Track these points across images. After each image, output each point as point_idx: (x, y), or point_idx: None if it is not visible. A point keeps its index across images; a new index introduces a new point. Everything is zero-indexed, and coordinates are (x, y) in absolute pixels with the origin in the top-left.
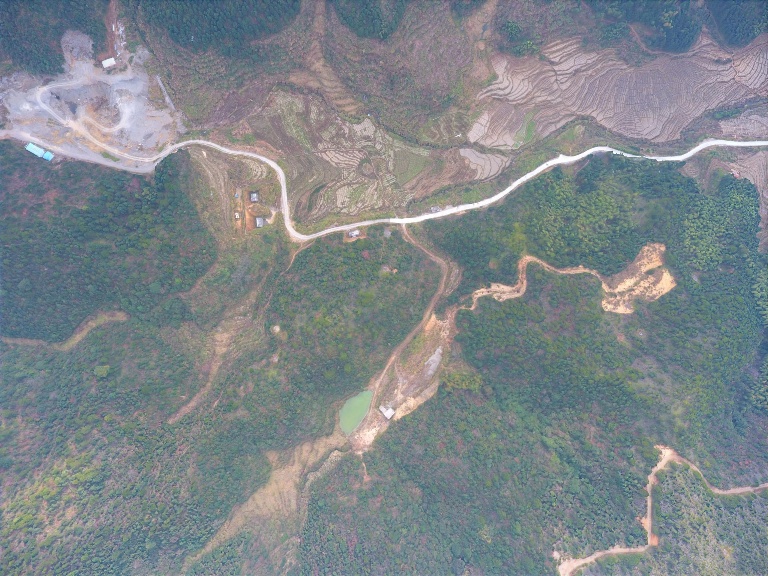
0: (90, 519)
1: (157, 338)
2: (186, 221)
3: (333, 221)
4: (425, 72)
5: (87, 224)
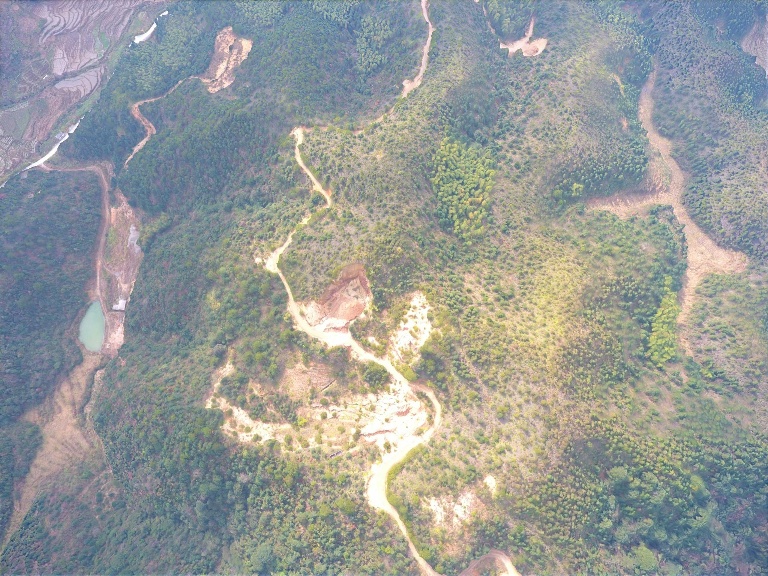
0: None
1: None
2: None
3: None
4: None
5: None
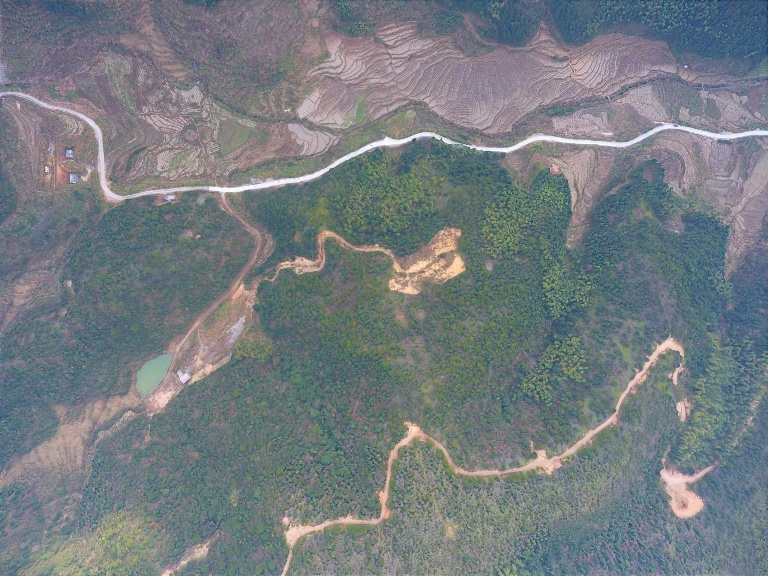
0: None
1: None
2: None
3: (151, 184)
4: (252, 43)
5: None
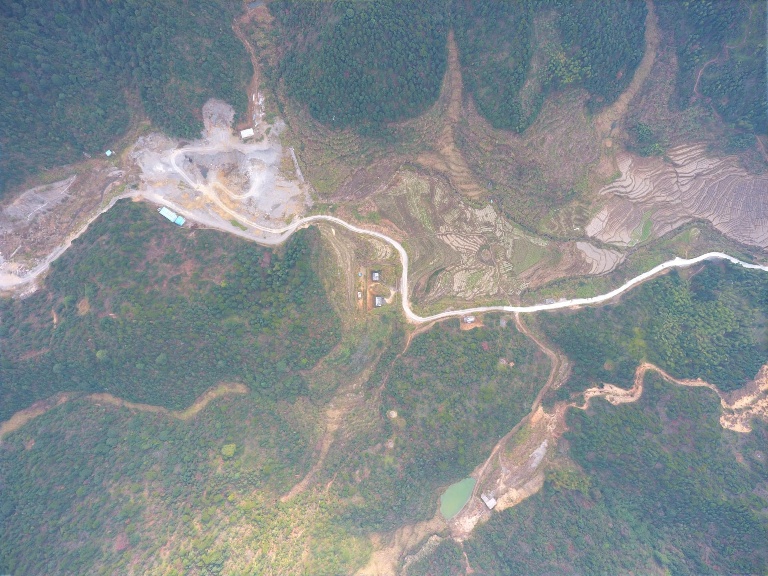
0: None
1: (275, 414)
2: (316, 301)
3: (449, 305)
4: (554, 167)
5: (225, 301)
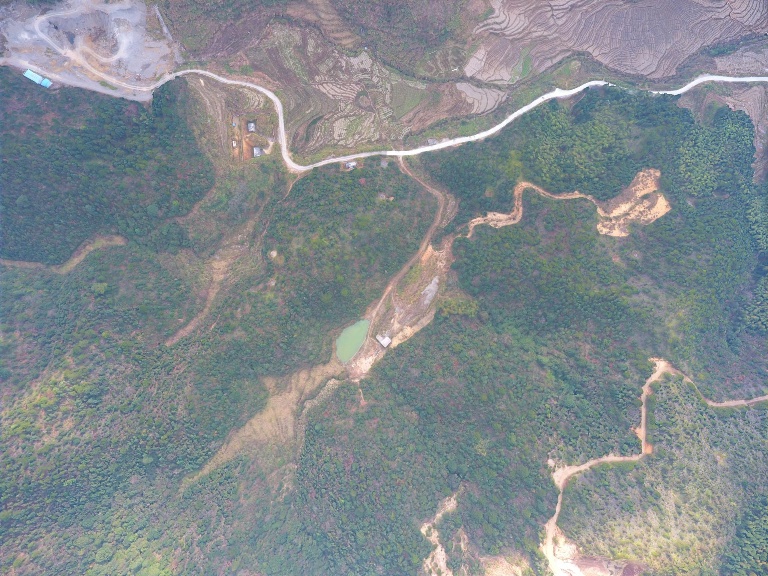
0: (88, 431)
1: (155, 262)
2: (183, 145)
3: (330, 153)
4: (422, 4)
5: (85, 143)
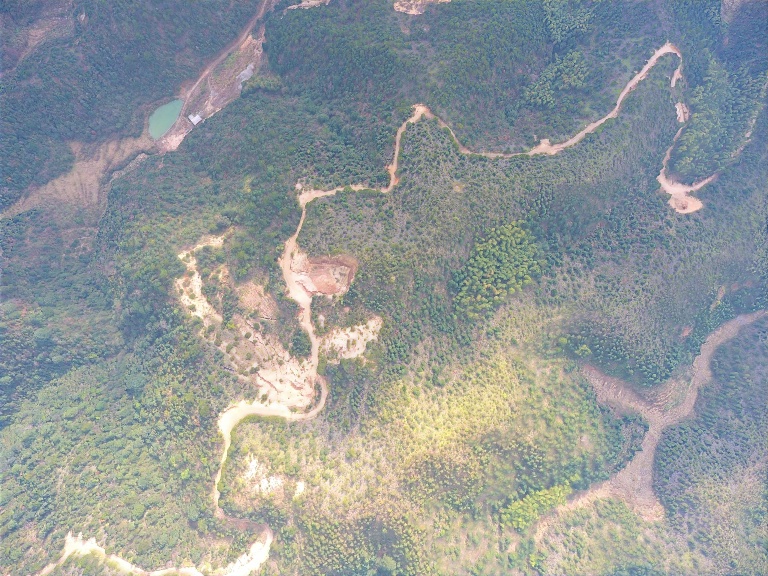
0: None
1: None
2: None
3: None
4: None
5: None
